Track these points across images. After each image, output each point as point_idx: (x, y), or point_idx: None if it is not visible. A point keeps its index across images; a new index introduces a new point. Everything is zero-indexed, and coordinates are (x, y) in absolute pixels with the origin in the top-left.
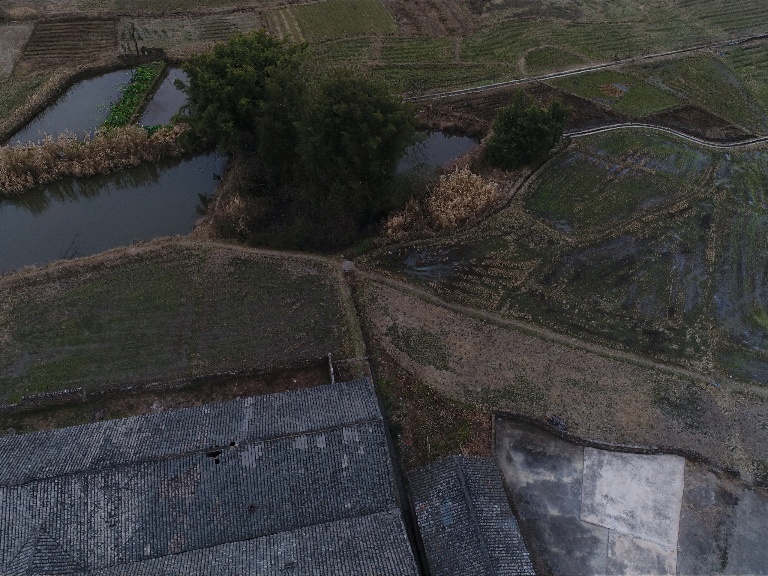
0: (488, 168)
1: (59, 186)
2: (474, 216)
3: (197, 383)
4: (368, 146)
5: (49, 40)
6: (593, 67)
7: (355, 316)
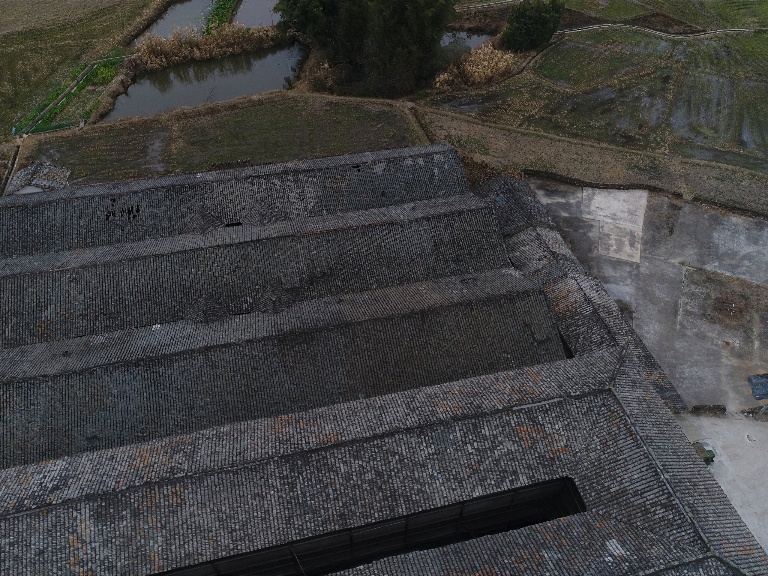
0: (504, 51)
1: None
2: (498, 76)
3: None
4: (425, 16)
5: None
6: None
7: (421, 130)
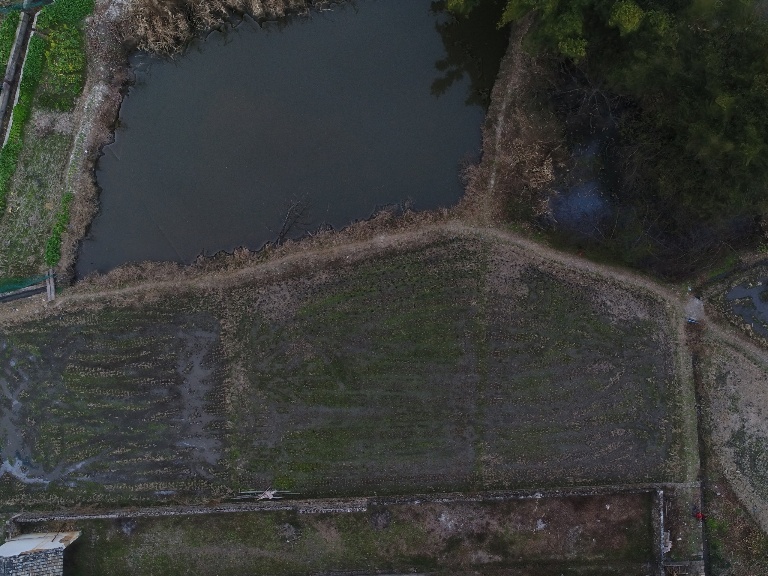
0: None
1: None
2: None
3: (493, 499)
4: None
5: None
6: None
7: (693, 411)
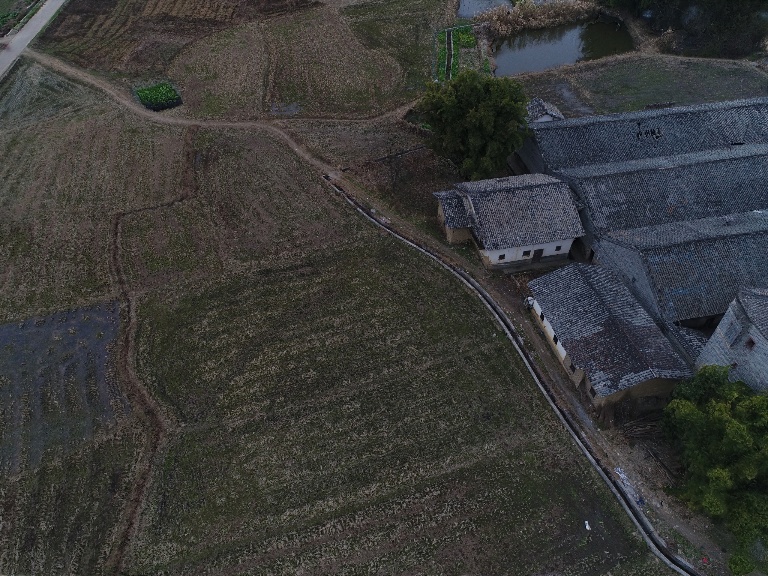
0: None
1: (511, 38)
2: None
3: None
4: None
5: None
6: None
7: None
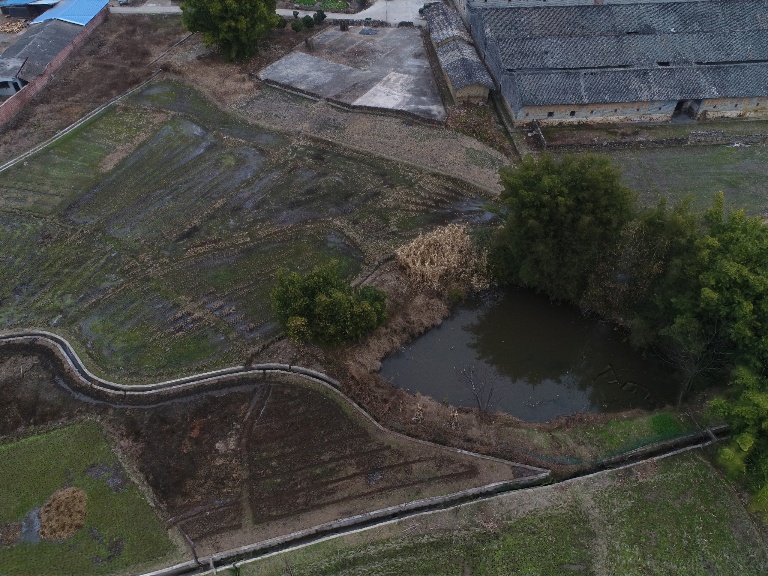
0: None
1: None
2: None
3: None
4: None
5: None
6: None
7: None
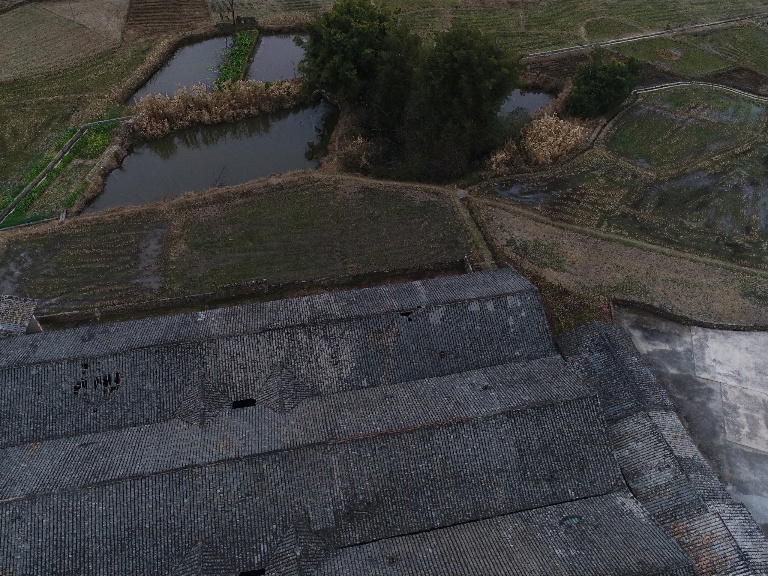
0: (568, 118)
1: (186, 134)
2: (565, 154)
3: (357, 279)
4: (483, 87)
5: (147, 11)
6: (648, 35)
7: (477, 231)
